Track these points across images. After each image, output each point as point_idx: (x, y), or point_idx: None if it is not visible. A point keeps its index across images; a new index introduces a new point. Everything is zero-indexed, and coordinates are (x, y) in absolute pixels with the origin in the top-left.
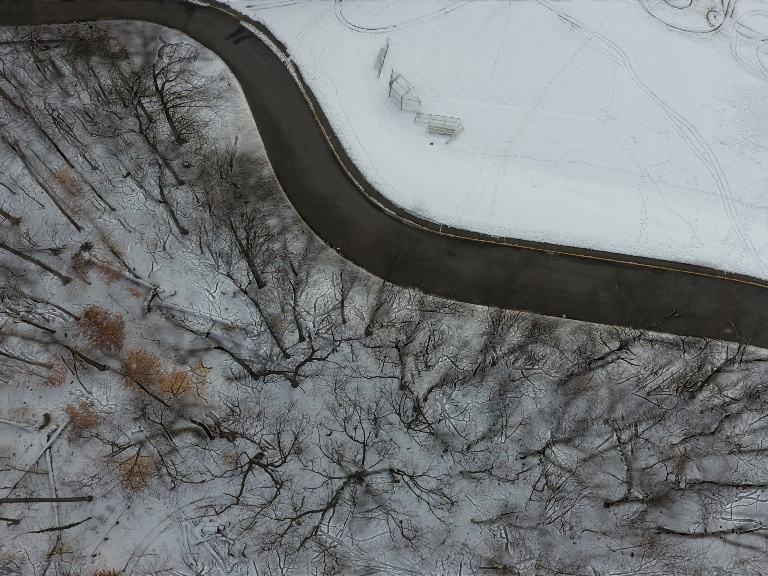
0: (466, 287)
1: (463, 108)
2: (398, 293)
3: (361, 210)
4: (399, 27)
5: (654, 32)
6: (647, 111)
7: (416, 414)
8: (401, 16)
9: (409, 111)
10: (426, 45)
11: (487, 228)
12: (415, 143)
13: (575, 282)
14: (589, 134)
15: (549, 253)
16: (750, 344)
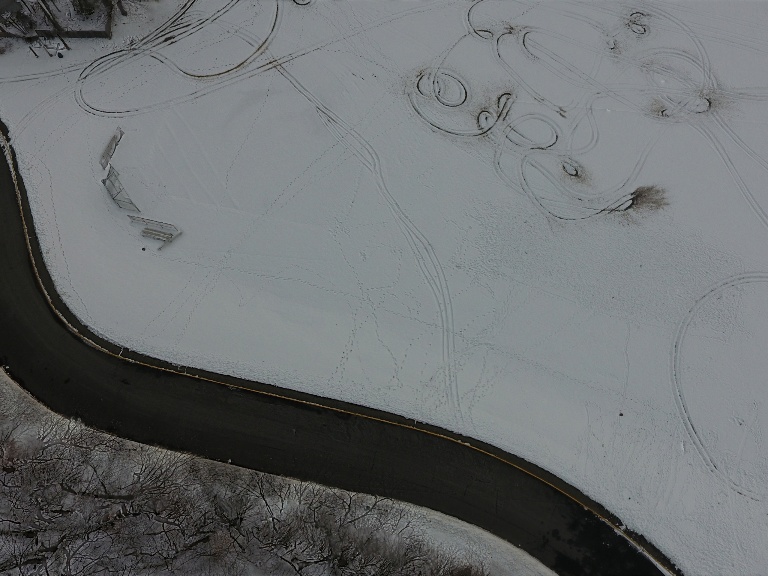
0: (131, 421)
1: (187, 209)
2: (57, 424)
3: (43, 324)
4: (141, 111)
5: (415, 133)
6: (385, 224)
7: (39, 566)
8: (147, 99)
9: (128, 210)
10: (165, 134)
11: (169, 355)
12: (125, 247)
13: (250, 423)
14: (316, 248)
15: (230, 387)
16: (424, 506)
